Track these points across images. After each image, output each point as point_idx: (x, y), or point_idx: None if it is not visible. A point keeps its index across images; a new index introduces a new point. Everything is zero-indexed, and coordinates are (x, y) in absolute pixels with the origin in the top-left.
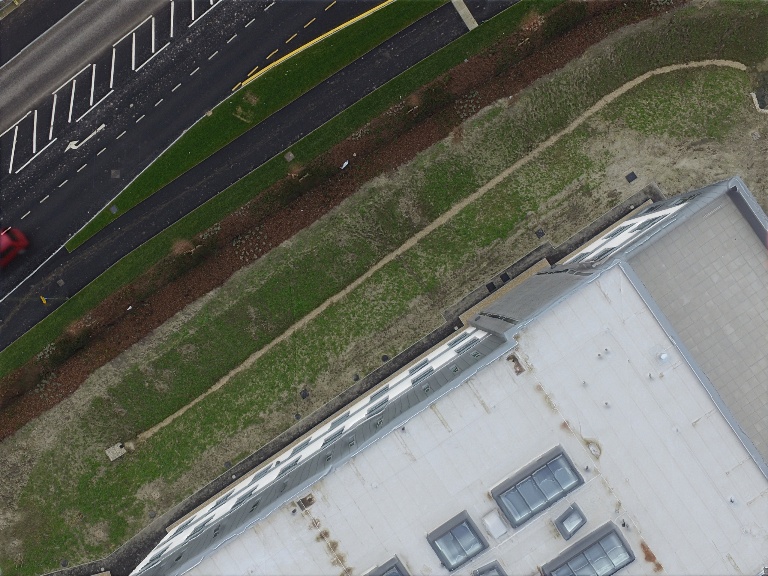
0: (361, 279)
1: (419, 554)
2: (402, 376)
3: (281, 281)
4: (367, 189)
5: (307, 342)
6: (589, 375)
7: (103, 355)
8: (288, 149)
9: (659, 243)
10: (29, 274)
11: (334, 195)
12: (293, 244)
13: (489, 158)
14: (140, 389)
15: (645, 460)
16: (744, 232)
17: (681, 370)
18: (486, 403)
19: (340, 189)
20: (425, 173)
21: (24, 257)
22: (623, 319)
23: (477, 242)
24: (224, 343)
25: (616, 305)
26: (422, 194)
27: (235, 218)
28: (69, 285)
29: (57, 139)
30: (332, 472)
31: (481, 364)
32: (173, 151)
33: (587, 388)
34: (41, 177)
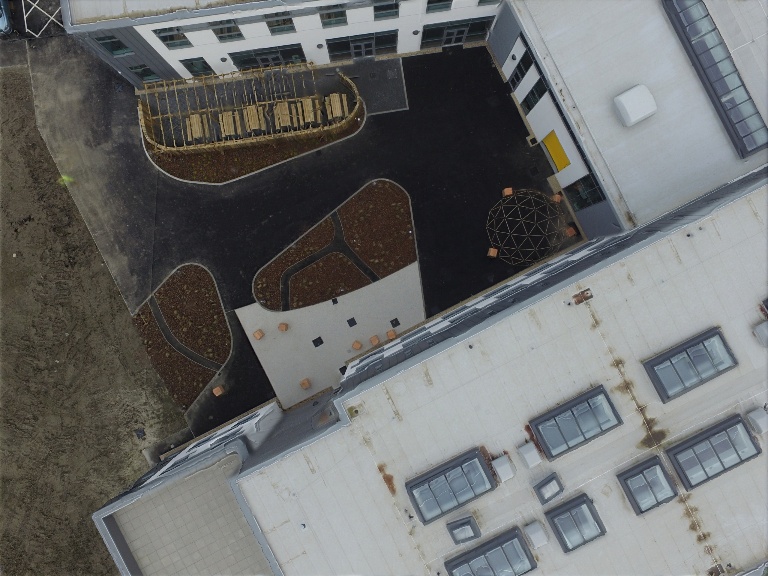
0: None
1: (612, 509)
2: None
3: None
4: None
5: None
6: None
7: None
8: None
9: None
10: None
11: None
12: None
13: None
14: None
15: (381, 573)
16: None
17: None
18: None
19: None
20: None
21: None
22: None
23: None
24: None
25: None
26: None
27: None
28: None
29: None
30: None
31: None
32: None
33: None
34: None
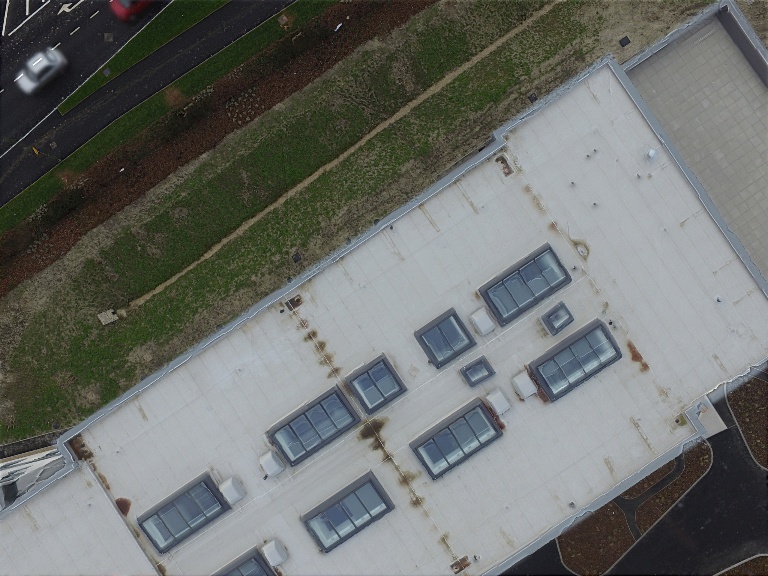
0: (354, 148)
1: (406, 354)
2: None
3: (274, 145)
4: (360, 52)
5: (299, 209)
6: (577, 176)
7: (95, 217)
8: (281, 12)
9: (650, 69)
10: (22, 137)
11: (327, 58)
12: (286, 107)
13: (483, 25)
14: (132, 253)
15: (633, 260)
16: (735, 58)
17: (669, 170)
18: (474, 204)
19: (333, 52)
20: (418, 37)
21: (17, 120)
22: (612, 120)
23: (470, 107)
24: (216, 208)
25: (605, 106)
26: (415, 60)
27: (228, 80)
28: (62, 147)
29: (50, 1)
30: (320, 272)
31: (470, 163)
32: (166, 14)
33: (575, 189)
34: (34, 39)
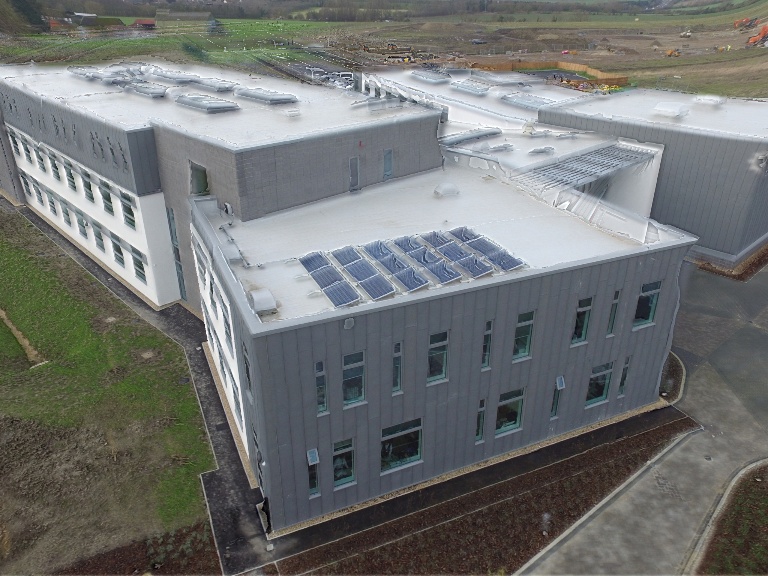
0: None
1: None
2: (45, 204)
3: None
4: None
5: None
6: None
7: None
8: None
9: None
10: None
11: None
12: None
13: None
14: None
15: None
16: None
17: None
18: None
19: None
20: None
21: None
22: None
23: None
24: None
25: None
26: None
27: None
28: None
29: None
30: None
31: None
32: None
33: None
34: None
